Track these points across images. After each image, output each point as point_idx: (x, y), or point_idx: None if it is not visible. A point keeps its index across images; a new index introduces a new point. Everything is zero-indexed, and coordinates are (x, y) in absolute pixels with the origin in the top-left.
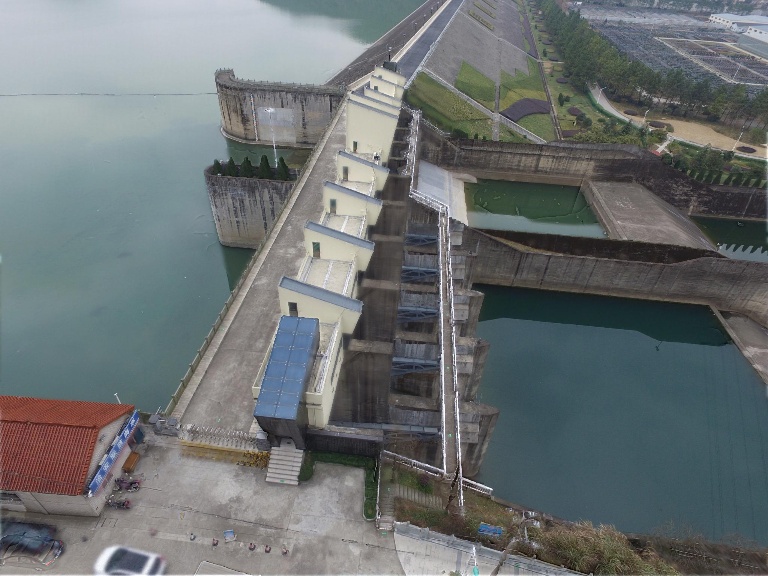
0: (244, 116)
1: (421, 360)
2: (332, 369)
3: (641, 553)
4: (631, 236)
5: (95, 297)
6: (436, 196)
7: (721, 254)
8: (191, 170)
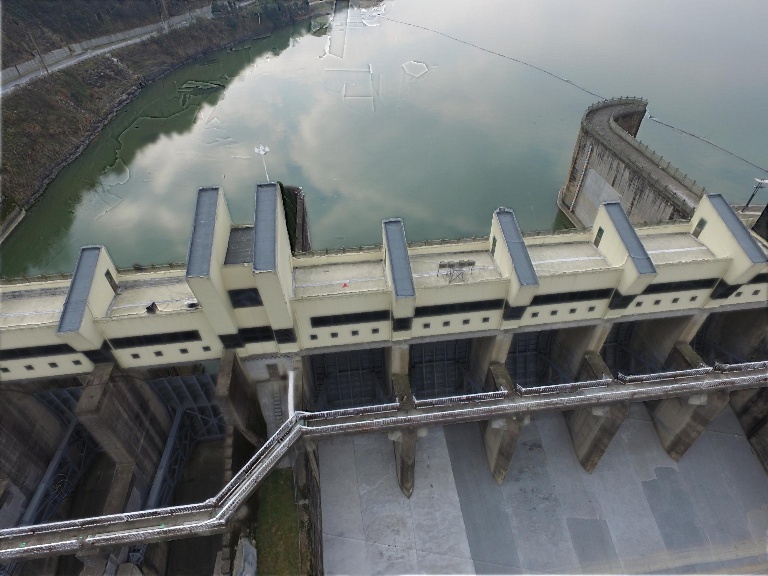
0: (574, 171)
1: None
2: None
3: None
4: None
5: (189, 232)
6: (609, 531)
7: None
8: (452, 195)
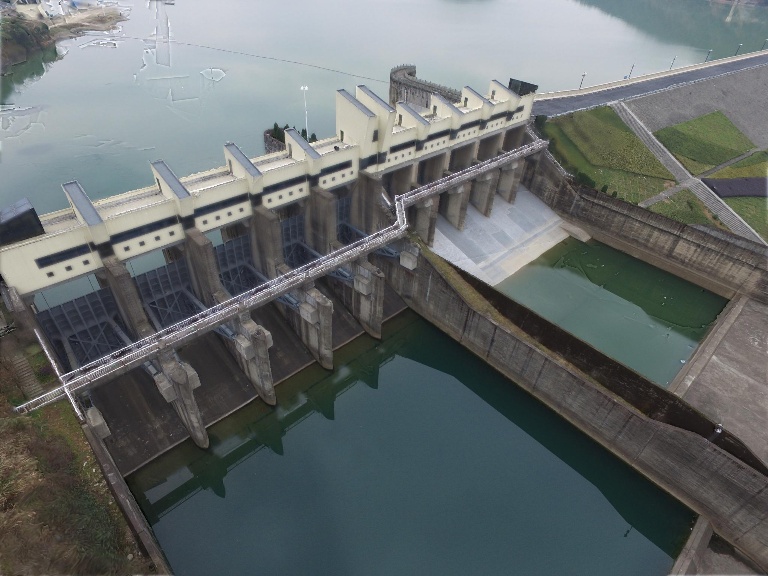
0: None
1: (224, 325)
2: (44, 254)
3: (9, 508)
4: (707, 380)
5: None
6: (506, 233)
7: (752, 452)
8: None
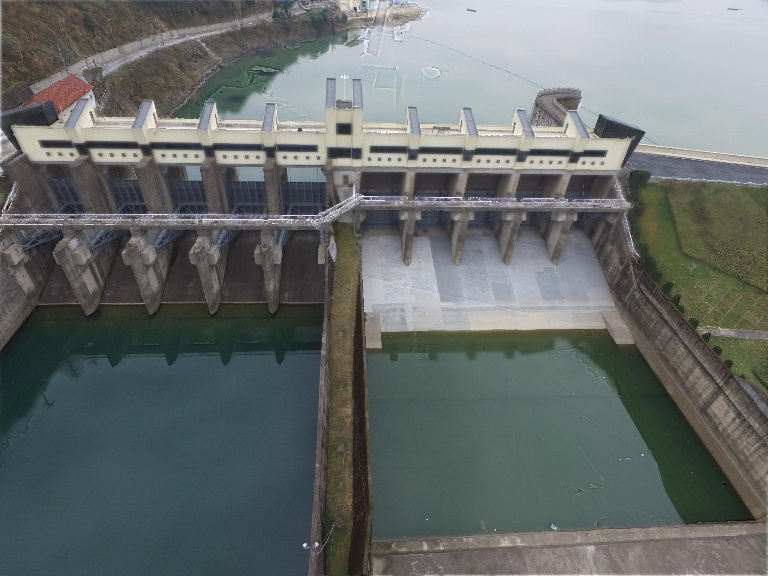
0: None
1: None
2: (44, 138)
3: None
4: (538, 560)
5: None
6: (513, 289)
7: None
8: None
